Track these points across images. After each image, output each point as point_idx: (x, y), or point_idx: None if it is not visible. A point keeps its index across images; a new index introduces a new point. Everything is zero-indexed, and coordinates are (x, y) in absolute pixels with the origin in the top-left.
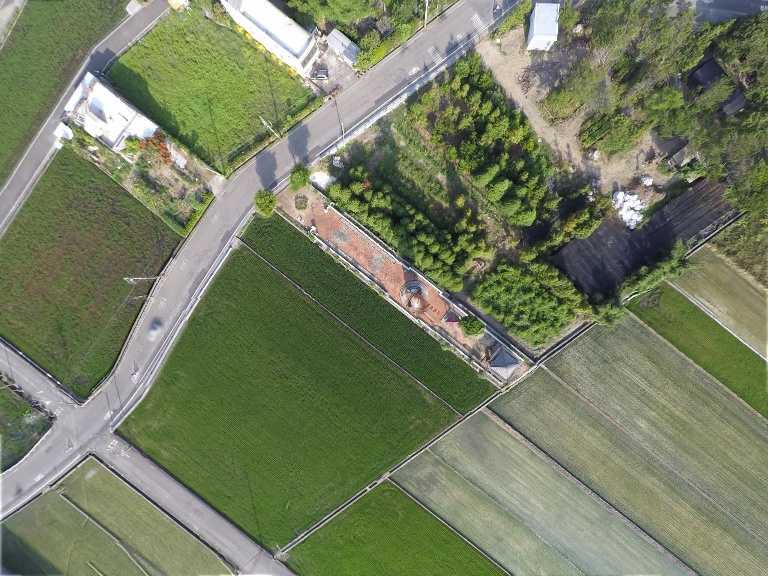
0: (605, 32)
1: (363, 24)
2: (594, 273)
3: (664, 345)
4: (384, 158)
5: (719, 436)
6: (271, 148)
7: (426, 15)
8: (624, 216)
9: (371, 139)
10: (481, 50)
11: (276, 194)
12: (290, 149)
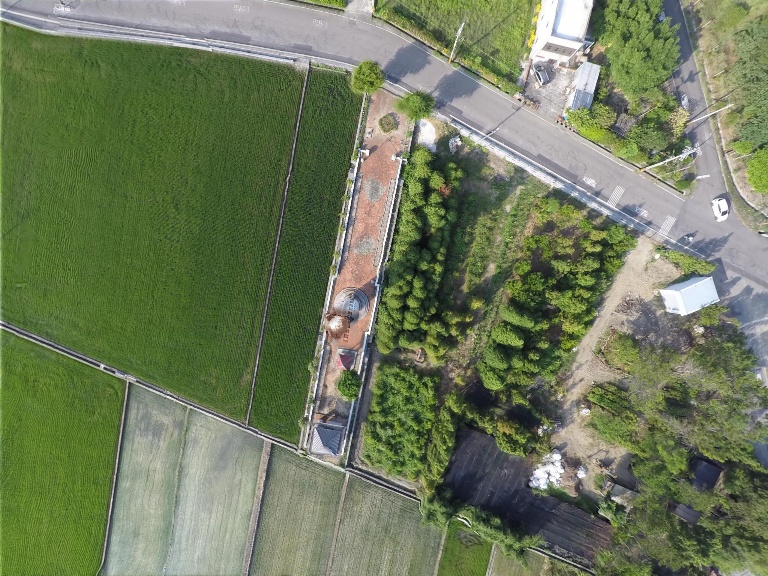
0: (712, 361)
1: (616, 98)
2: (469, 474)
3: (431, 574)
4: (483, 195)
5: None
6: (434, 55)
7: (656, 165)
8: (538, 471)
9: (497, 170)
10: (641, 243)
11: (384, 87)
12: (443, 79)
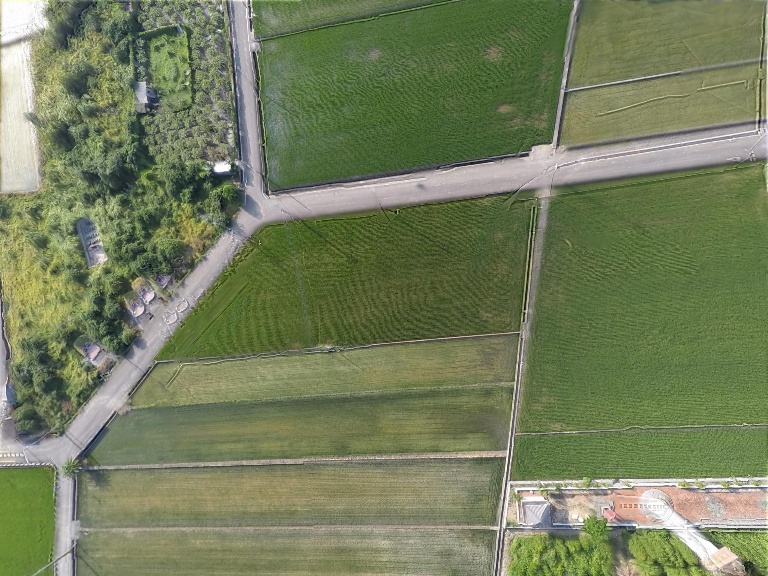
0: None
1: None
2: None
3: None
4: None
5: None
6: None
7: None
8: None
9: None
10: None
11: None
12: None
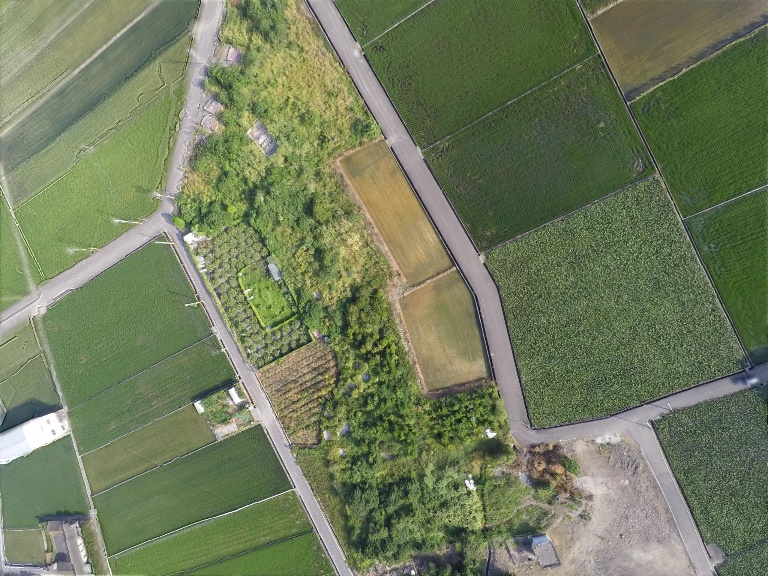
0: None
1: None
2: None
3: None
4: None
5: (16, 3)
6: None
7: None
8: None
9: None
10: None
11: None
12: None
